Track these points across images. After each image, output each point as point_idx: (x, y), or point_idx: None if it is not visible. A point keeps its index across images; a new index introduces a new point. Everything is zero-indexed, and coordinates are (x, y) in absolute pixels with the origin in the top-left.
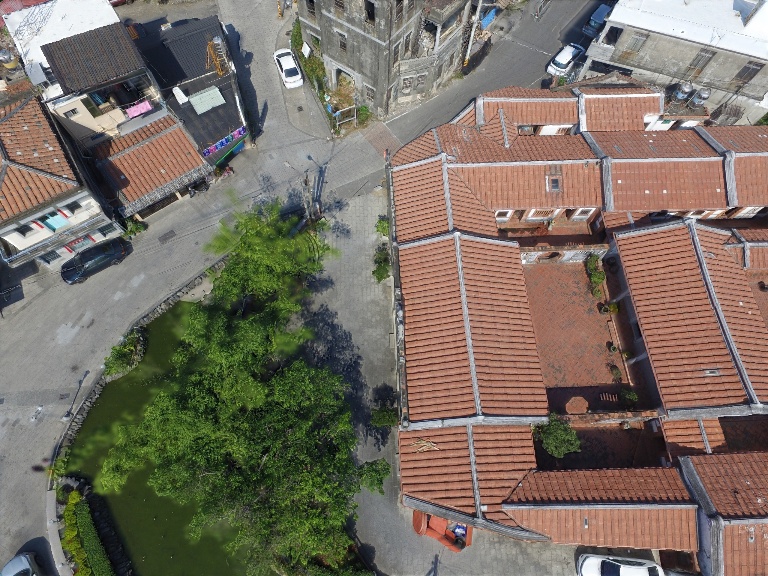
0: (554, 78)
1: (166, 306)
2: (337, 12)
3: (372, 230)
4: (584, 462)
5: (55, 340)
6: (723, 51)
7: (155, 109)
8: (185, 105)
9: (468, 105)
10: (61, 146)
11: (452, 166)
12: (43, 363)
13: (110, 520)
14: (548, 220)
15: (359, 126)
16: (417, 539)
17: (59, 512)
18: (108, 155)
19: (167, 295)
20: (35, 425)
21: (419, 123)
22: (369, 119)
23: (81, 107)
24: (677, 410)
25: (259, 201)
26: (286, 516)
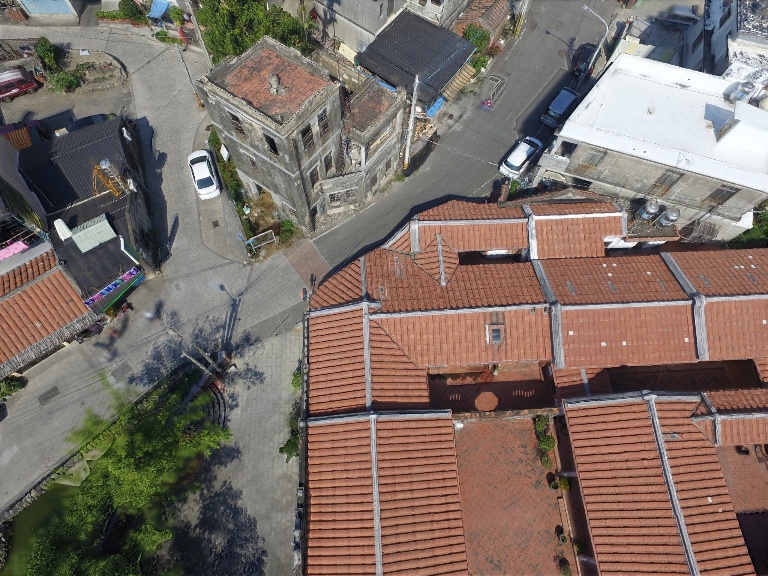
0: (503, 189)
1: (37, 493)
2: (239, 137)
3: (290, 379)
4: None
5: None
6: (692, 173)
7: (37, 241)
8: (68, 241)
9: (403, 226)
10: None
11: (375, 317)
12: None
13: None
14: (493, 364)
15: (282, 245)
16: None
17: None
18: None
19: (42, 474)
20: None
21: (351, 239)
22: (294, 236)
23: None
24: None
25: (160, 346)
26: None
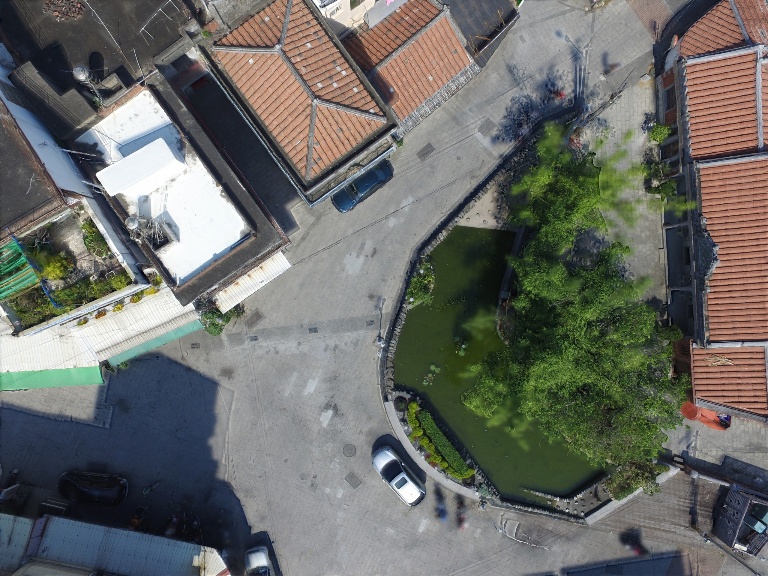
0: None
1: (446, 233)
2: None
3: (638, 133)
4: None
5: (345, 271)
6: None
7: None
8: None
9: None
10: (350, 67)
11: (766, 62)
12: (341, 293)
13: (441, 421)
14: None
15: None
16: None
17: (399, 417)
18: (371, 61)
19: (440, 219)
20: (353, 349)
21: None
22: None
23: (346, 1)
24: None
25: (517, 102)
26: (638, 431)
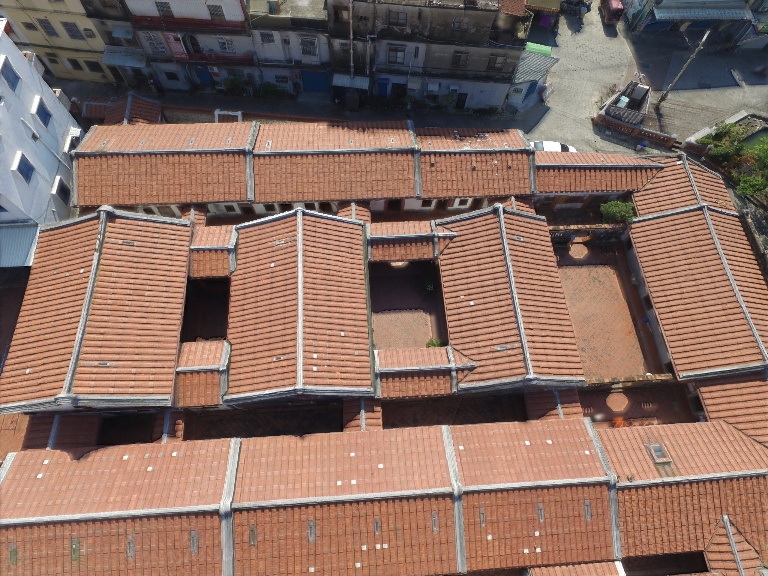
0: None
1: None
2: None
3: None
4: (571, 216)
5: None
6: None
7: None
8: None
9: None
10: None
11: None
12: None
13: None
14: None
15: None
16: None
17: None
18: None
19: None
20: None
21: None
22: None
23: None
24: (542, 219)
25: None
26: None
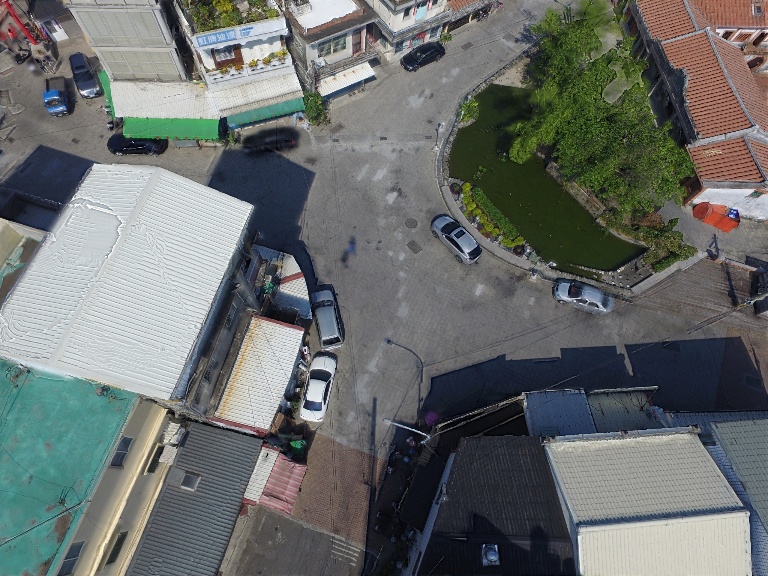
0: None
1: (485, 85)
2: None
3: None
4: None
5: (409, 105)
6: None
7: None
8: None
9: None
10: None
11: None
12: (406, 118)
13: None
14: (742, 46)
15: None
16: (699, 225)
17: (454, 198)
18: None
19: (479, 81)
20: (415, 153)
21: None
22: None
23: None
24: None
25: (528, 26)
26: (658, 162)
